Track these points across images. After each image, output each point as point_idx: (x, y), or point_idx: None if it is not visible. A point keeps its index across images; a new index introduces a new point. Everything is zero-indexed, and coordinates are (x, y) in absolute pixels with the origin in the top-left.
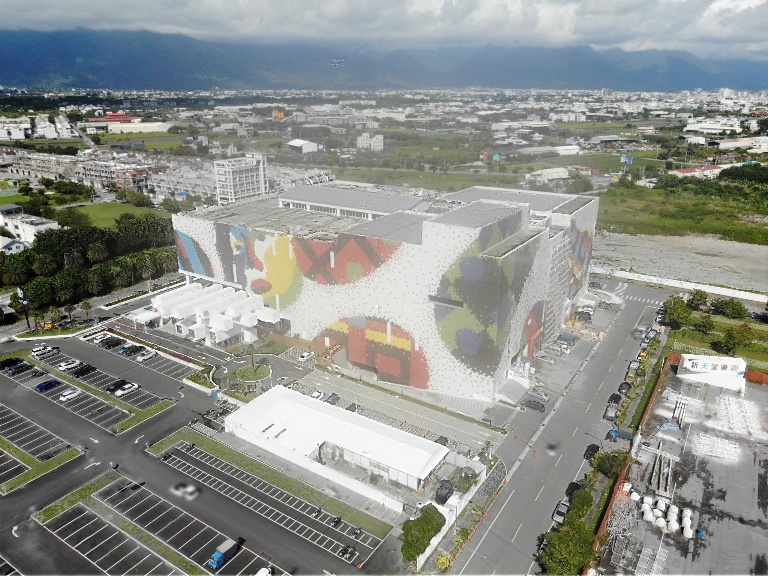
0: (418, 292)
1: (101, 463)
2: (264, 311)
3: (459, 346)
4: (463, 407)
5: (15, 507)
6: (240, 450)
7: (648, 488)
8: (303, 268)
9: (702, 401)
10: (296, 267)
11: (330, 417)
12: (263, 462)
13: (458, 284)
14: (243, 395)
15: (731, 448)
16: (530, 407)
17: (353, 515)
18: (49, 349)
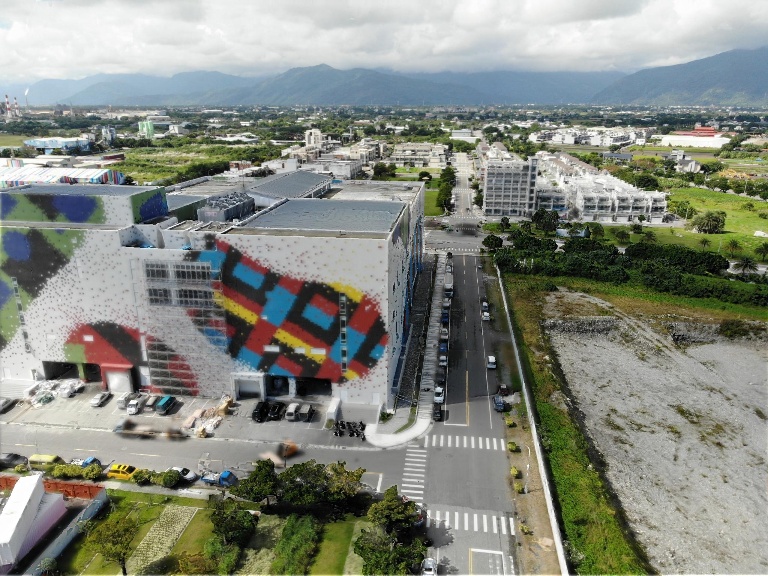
0: None
1: None
2: None
3: None
4: None
5: None
6: None
7: None
8: None
9: None
10: None
11: None
12: None
13: None
14: None
15: None
16: None
17: None
18: None
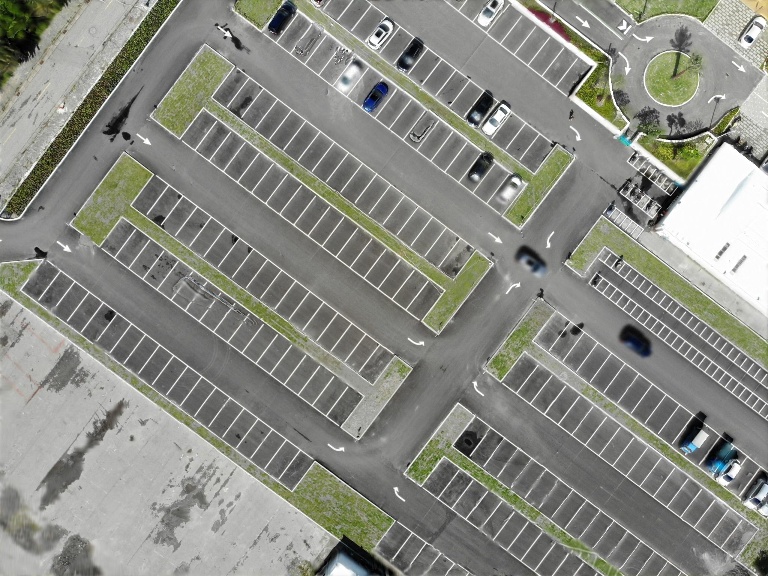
0: None
1: (521, 285)
2: None
3: None
4: None
5: (460, 354)
6: (679, 271)
7: None
8: None
9: None
10: None
11: None
12: (710, 297)
13: None
14: (674, 159)
15: None
16: None
17: None
18: None
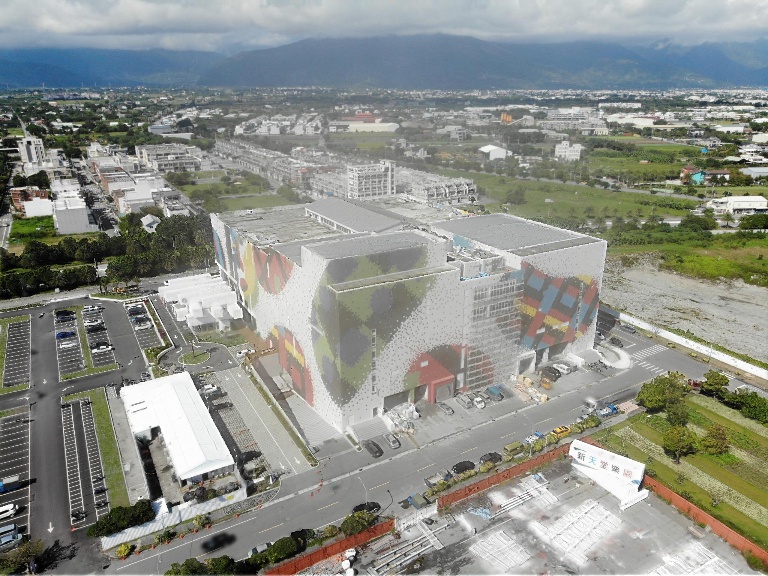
0: (303, 312)
1: (29, 398)
2: (231, 307)
3: (324, 372)
4: (316, 431)
5: None
6: (113, 415)
7: (372, 562)
8: (258, 274)
9: (562, 499)
10: (256, 272)
11: (179, 407)
12: (115, 429)
13: (319, 311)
14: None
15: (520, 558)
16: (368, 449)
17: (117, 490)
18: (96, 308)
